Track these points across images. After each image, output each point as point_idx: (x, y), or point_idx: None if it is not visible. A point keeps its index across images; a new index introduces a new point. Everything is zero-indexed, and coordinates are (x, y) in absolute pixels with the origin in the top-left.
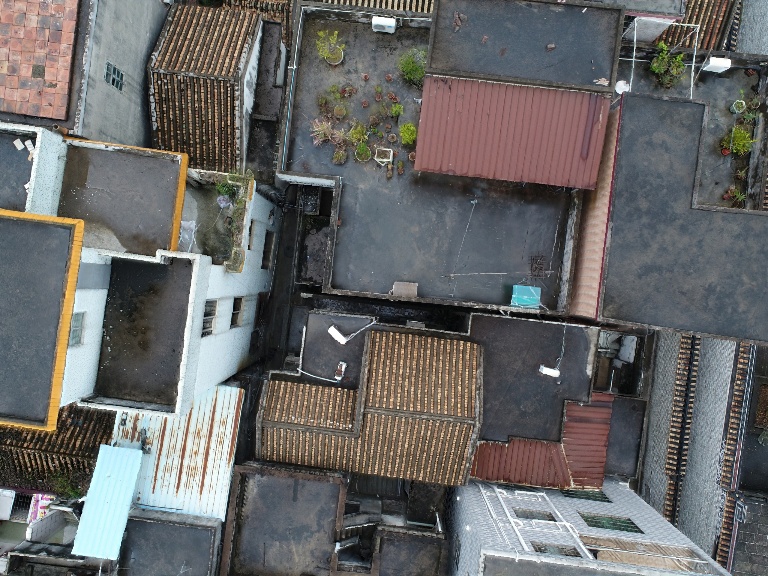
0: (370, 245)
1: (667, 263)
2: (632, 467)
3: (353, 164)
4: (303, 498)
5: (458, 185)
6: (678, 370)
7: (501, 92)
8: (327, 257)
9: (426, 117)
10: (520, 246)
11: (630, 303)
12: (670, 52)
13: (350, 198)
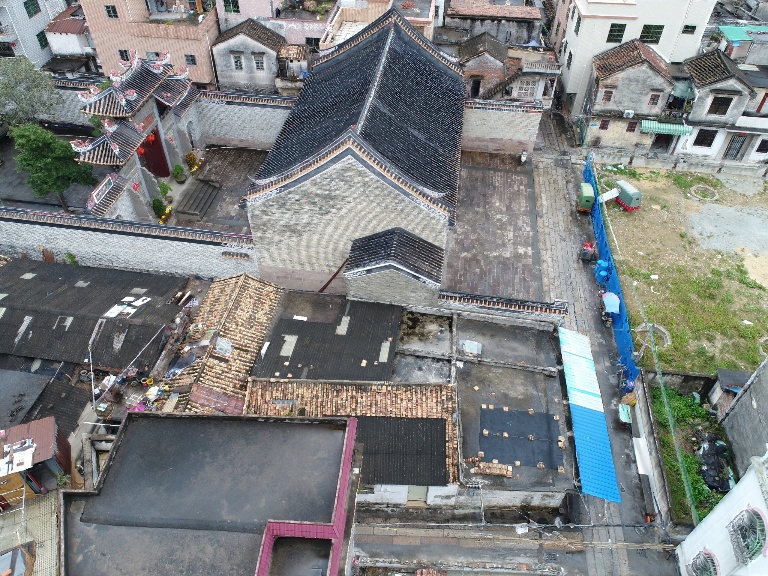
0: None
1: None
2: None
3: None
4: None
5: None
6: None
7: None
8: None
9: None
10: None
11: None
12: None
13: None
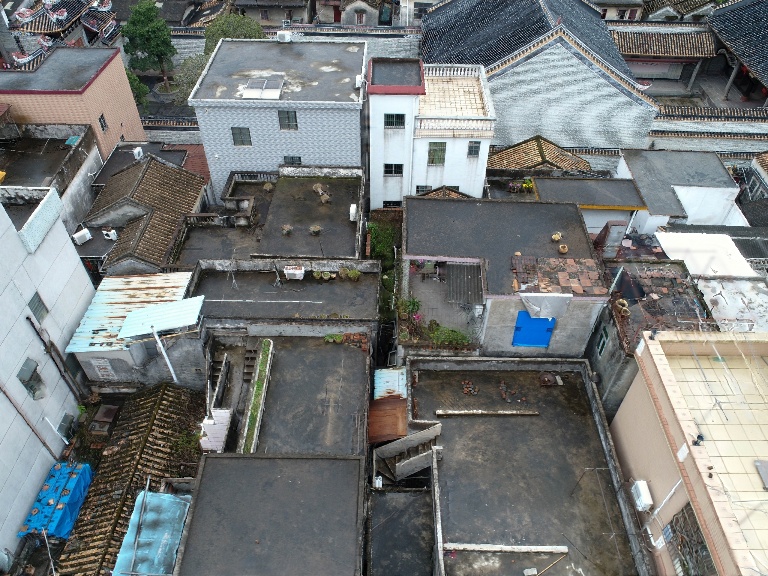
0: None
1: (60, 76)
2: None
3: None
4: (201, 245)
5: None
6: None
7: None
8: None
9: None
10: (47, 154)
11: (76, 84)
12: None
13: None
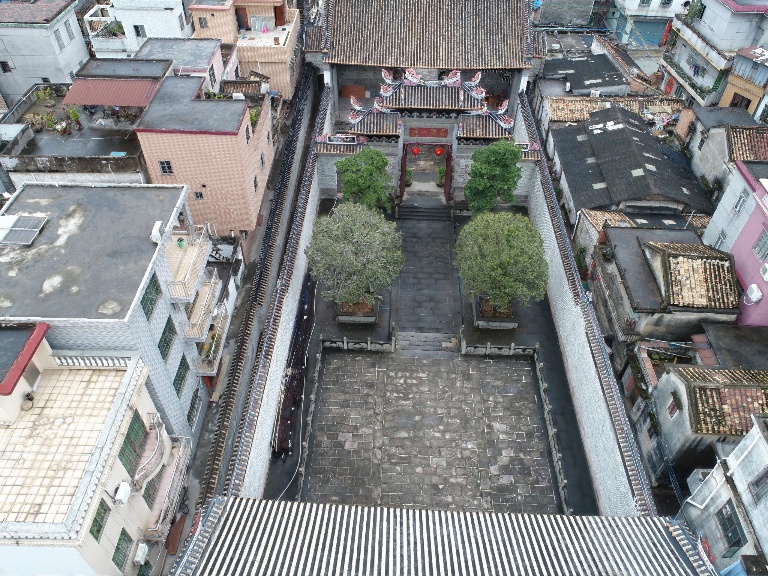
0: (41, 154)
1: (176, 113)
2: (220, 297)
3: (44, 132)
4: None
5: (99, 135)
6: (261, 254)
7: (111, 81)
8: (8, 145)
9: (73, 89)
10: None
11: (153, 124)
12: (217, 95)
13: (37, 141)
